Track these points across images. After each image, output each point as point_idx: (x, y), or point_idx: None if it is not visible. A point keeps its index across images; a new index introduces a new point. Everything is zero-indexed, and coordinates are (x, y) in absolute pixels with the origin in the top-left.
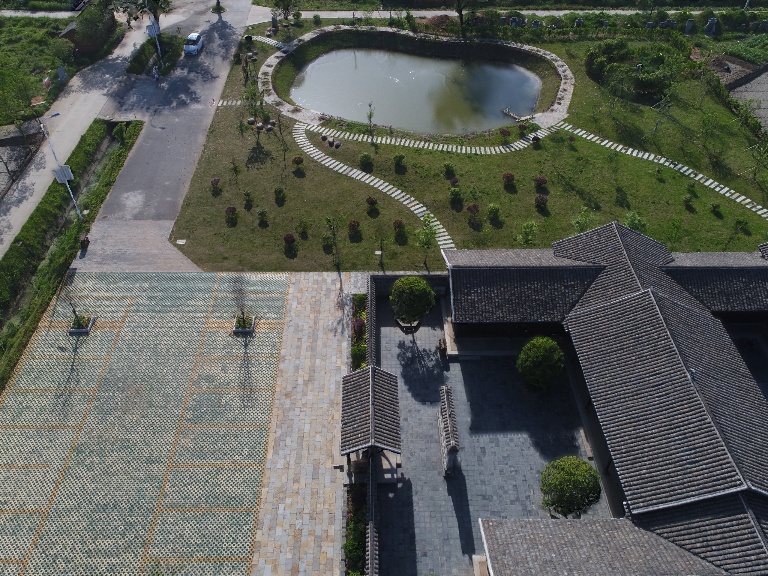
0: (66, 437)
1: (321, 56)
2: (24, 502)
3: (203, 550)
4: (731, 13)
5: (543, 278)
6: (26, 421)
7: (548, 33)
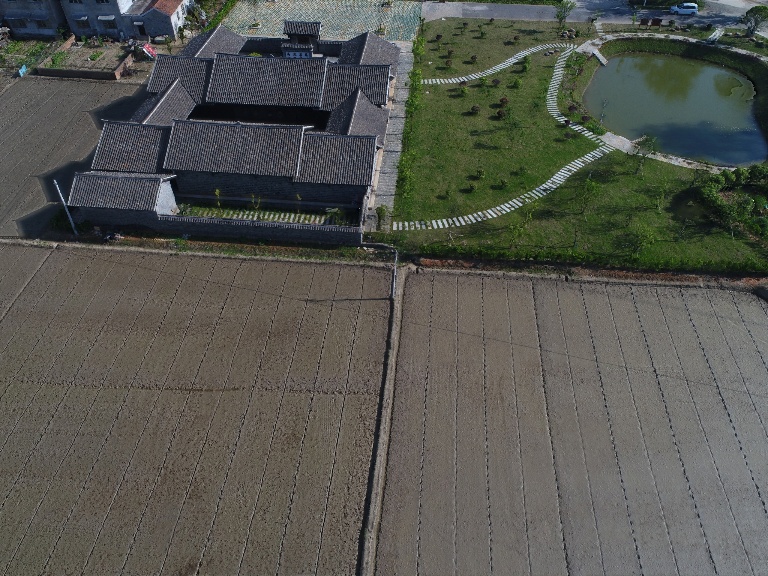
0: (332, 8)
1: (719, 65)
2: (308, 5)
3: None
4: None
5: None
6: (341, 2)
7: None
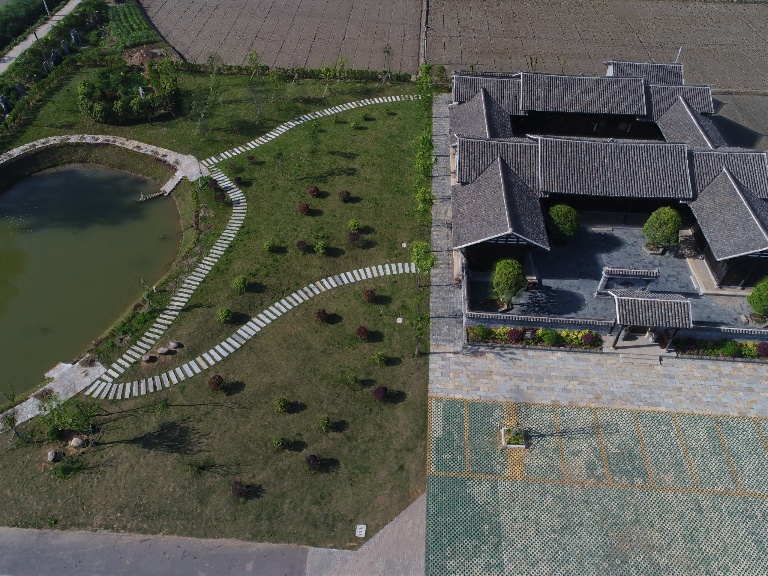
0: None
1: None
2: None
3: (761, 452)
4: (66, 20)
5: (511, 189)
6: None
7: (5, 127)
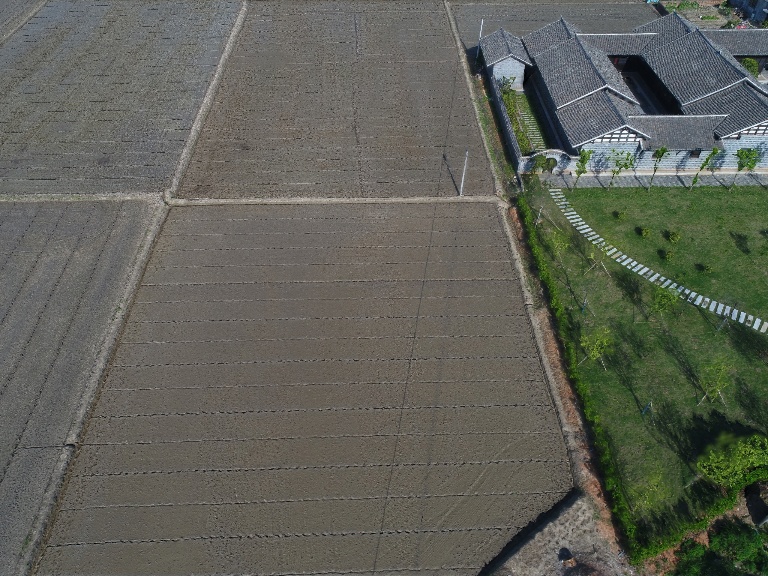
0: None
1: None
2: None
3: None
4: None
5: None
6: None
7: None
